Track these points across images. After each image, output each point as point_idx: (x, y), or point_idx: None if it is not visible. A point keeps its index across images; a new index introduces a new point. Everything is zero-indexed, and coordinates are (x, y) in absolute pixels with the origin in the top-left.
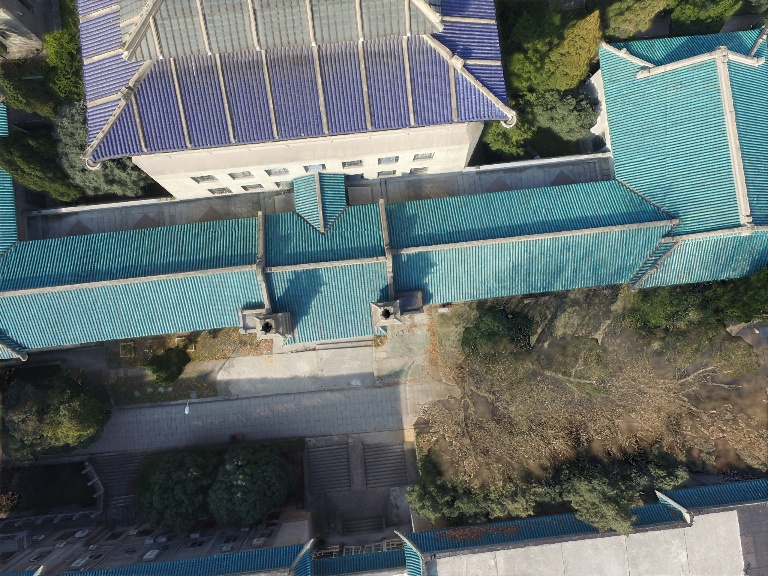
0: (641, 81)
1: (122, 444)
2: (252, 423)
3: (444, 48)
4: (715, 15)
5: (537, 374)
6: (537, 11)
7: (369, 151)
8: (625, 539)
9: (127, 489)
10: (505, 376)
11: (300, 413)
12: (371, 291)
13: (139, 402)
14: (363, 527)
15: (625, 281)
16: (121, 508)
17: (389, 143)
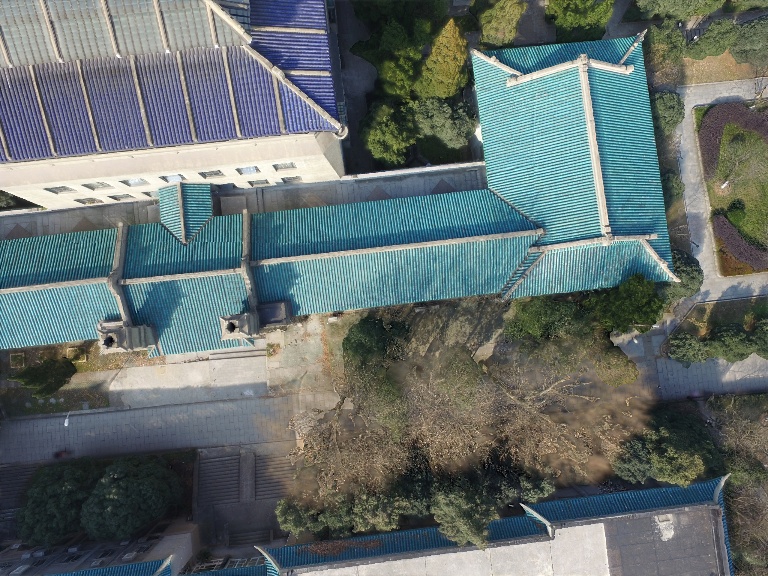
0: (511, 89)
1: (14, 456)
2: (145, 434)
3: (263, 59)
4: (593, 22)
5: (410, 385)
6: (428, 17)
7: (220, 162)
8: (490, 553)
9: (16, 502)
10: (370, 388)
11: (193, 424)
12: (233, 303)
13: (31, 413)
14: (250, 539)
15: (496, 291)
16: (9, 521)
17: (239, 154)
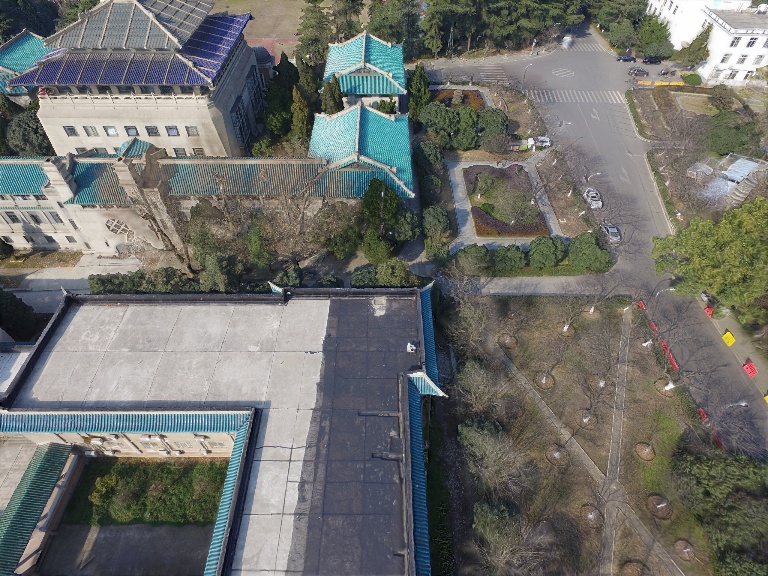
0: None
1: None
2: None
3: (186, 59)
4: None
5: None
6: None
7: (157, 117)
8: (234, 310)
9: None
10: None
11: None
12: None
13: None
14: None
15: None
16: None
17: (168, 113)
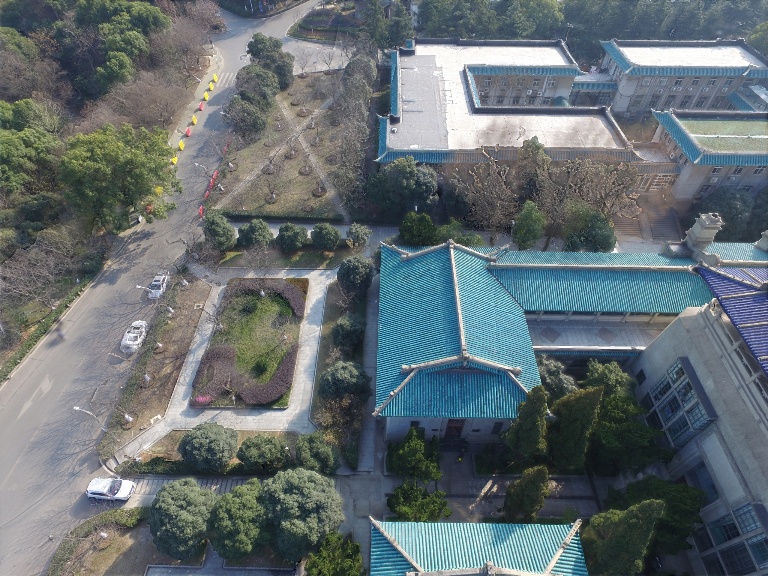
0: None
1: None
2: None
3: None
4: None
5: None
6: None
7: None
8: None
9: None
10: None
11: None
12: None
13: None
14: None
15: None
16: None
17: None
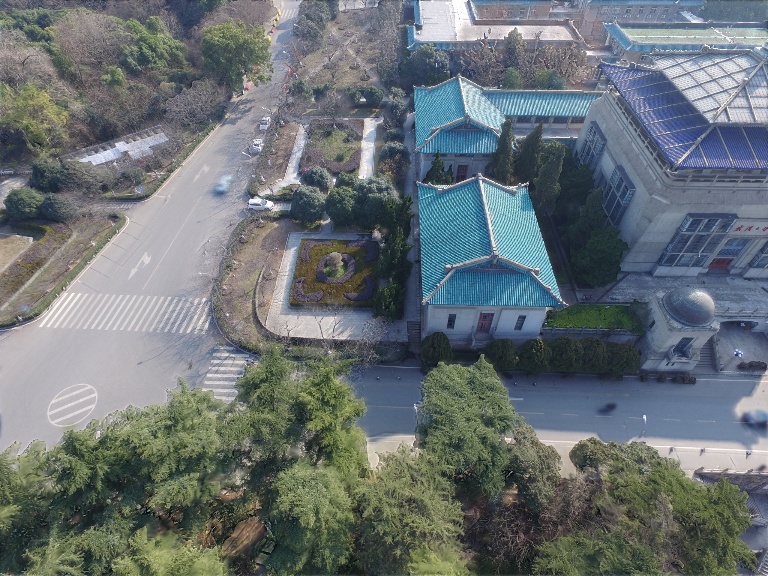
0: None
1: None
2: None
3: None
4: None
5: None
6: None
7: None
8: None
9: None
10: None
11: None
12: None
13: None
14: (590, 84)
15: None
16: None
17: None
